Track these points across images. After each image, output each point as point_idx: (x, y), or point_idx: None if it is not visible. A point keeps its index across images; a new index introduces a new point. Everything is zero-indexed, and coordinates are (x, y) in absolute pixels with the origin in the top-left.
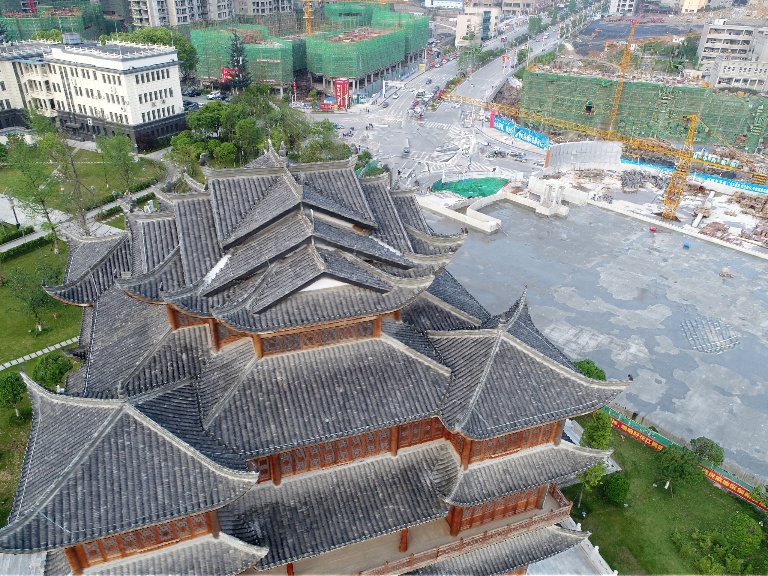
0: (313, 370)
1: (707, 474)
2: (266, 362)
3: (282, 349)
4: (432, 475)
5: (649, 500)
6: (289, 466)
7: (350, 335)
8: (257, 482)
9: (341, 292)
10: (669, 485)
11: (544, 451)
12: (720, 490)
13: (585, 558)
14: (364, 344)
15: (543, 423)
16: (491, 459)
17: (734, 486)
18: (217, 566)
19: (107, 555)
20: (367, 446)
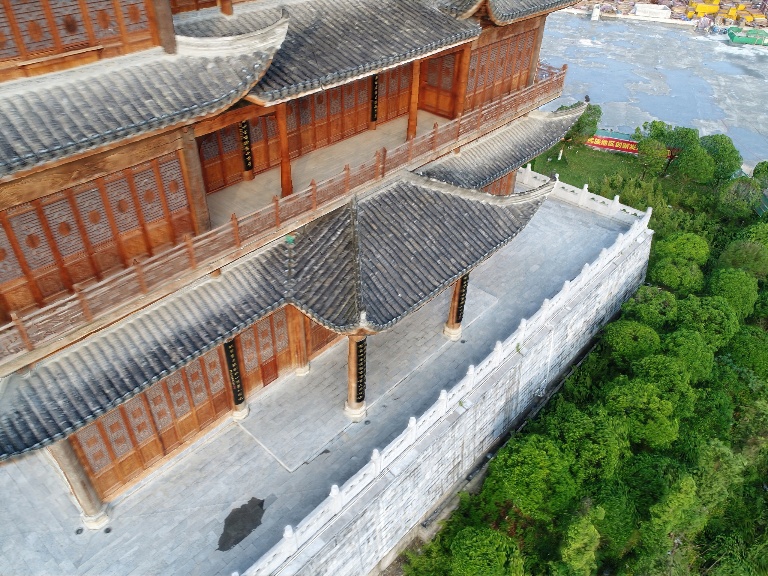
0: None
1: None
2: None
3: None
4: (436, 3)
5: (551, 170)
6: None
7: None
8: (195, 6)
9: None
10: (562, 154)
11: None
12: (601, 151)
13: None
14: None
15: None
16: None
17: (612, 142)
18: (195, 91)
19: None
20: None
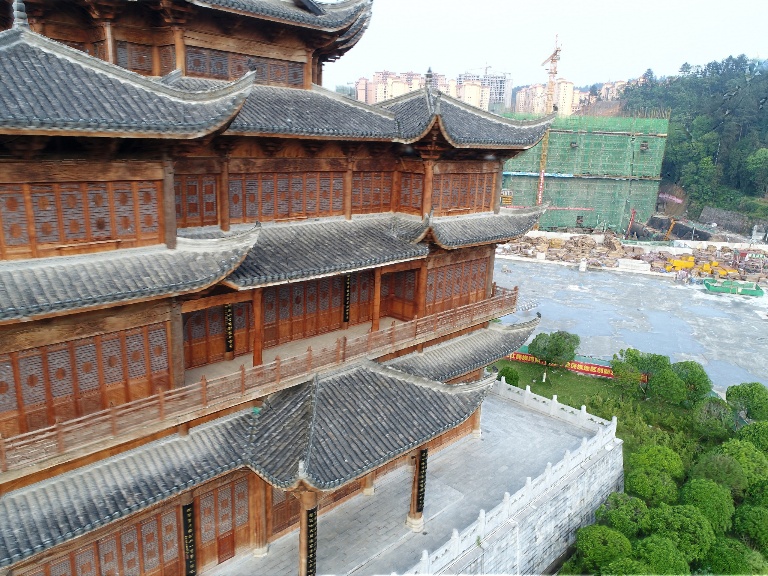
0: (251, 94)
1: (569, 367)
2: (192, 79)
3: (208, 73)
4: None
5: (536, 391)
6: (238, 206)
7: (280, 78)
8: (200, 224)
9: (274, 4)
10: None
11: (488, 217)
12: (584, 376)
13: (519, 406)
14: (297, 90)
15: (498, 145)
16: (448, 216)
17: (594, 368)
18: (183, 274)
19: (6, 245)
20: (321, 199)
